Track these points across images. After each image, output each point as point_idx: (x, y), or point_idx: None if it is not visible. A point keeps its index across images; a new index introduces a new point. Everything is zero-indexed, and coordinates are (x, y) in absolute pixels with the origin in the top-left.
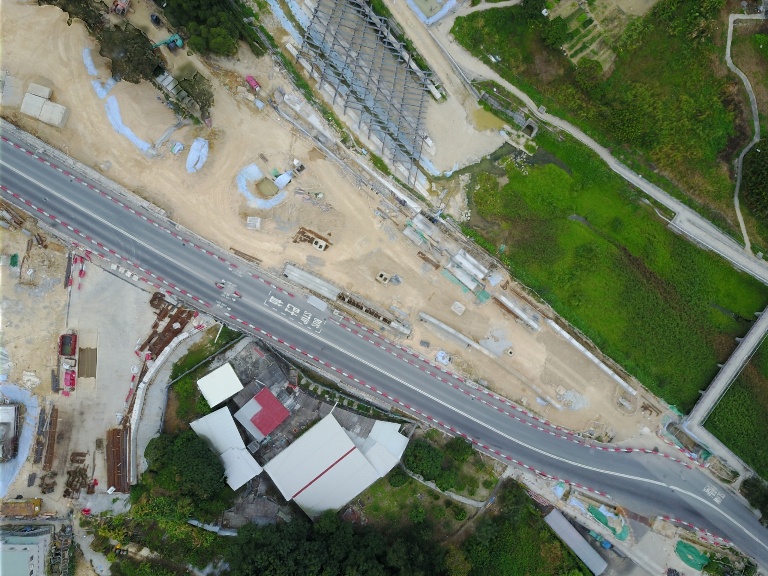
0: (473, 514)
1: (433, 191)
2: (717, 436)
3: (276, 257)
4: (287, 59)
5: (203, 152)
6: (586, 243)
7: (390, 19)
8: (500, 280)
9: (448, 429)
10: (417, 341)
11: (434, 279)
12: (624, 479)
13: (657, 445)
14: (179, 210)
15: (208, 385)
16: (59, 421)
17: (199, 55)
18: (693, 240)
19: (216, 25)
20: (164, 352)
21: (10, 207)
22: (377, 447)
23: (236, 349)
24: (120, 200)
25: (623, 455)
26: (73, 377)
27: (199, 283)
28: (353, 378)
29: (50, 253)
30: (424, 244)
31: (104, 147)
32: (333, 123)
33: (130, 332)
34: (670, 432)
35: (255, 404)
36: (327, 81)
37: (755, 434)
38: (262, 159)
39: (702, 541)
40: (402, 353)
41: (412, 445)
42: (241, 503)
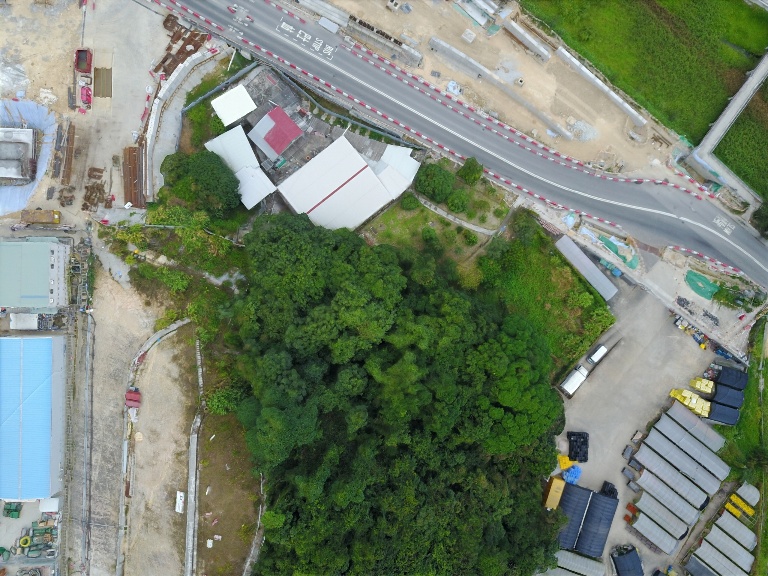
0: (484, 242)
1: None
2: None
3: None
4: None
5: None
6: None
7: None
8: (510, 12)
9: (459, 158)
10: (428, 71)
11: (444, 11)
12: (634, 210)
13: (667, 177)
14: None
15: (222, 105)
16: (76, 138)
17: None
18: None
19: None
20: (178, 68)
21: None
22: (389, 170)
23: (249, 78)
24: None
25: (633, 187)
26: (89, 94)
27: (212, 7)
28: (365, 104)
29: None
30: None
31: None
32: None
33: (144, 53)
34: (680, 165)
35: (268, 120)
36: None
37: (765, 167)
38: None
39: (712, 271)
40: (413, 82)
41: (424, 167)
42: None
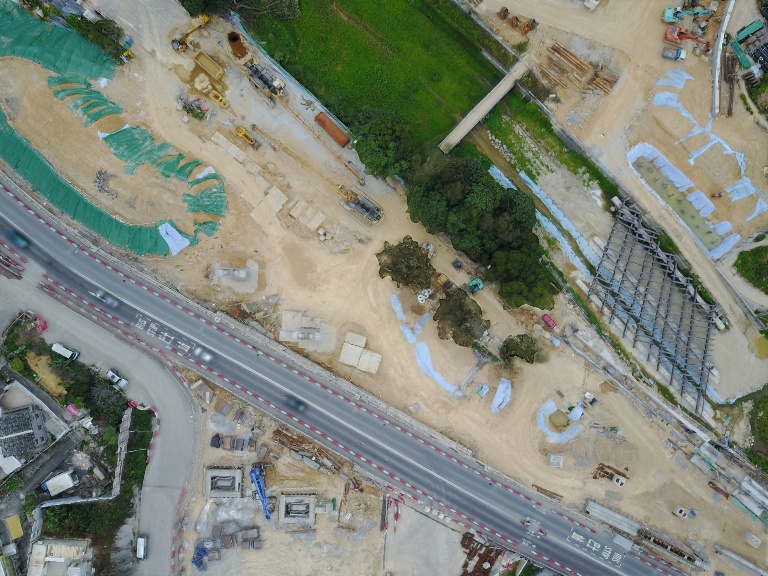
0: None
1: (718, 419)
2: None
3: (576, 493)
4: (576, 293)
5: (507, 393)
6: None
7: (676, 255)
8: None
9: None
10: (711, 572)
11: (725, 508)
12: None
13: None
14: (484, 449)
15: None
16: None
17: (498, 296)
18: None
19: (532, 281)
20: None
21: (328, 452)
22: None
23: None
24: (430, 442)
25: None
26: None
27: (505, 521)
28: None
29: (366, 496)
30: (710, 471)
31: (413, 390)
32: (623, 356)
33: (442, 572)
34: None
35: None
36: (616, 315)
37: None
38: (558, 395)
39: None
40: None
41: None
42: None
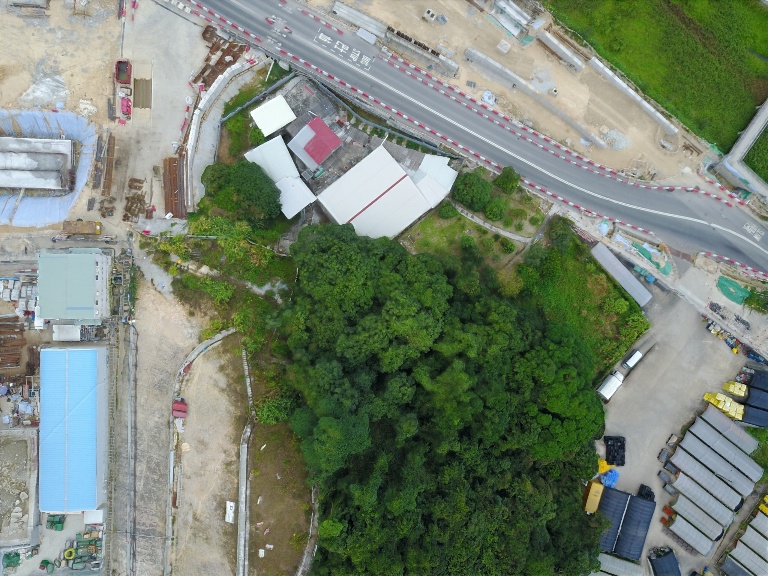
0: (521, 249)
1: None
2: None
3: None
4: None
5: None
6: None
7: None
8: (543, 23)
9: (495, 167)
10: (463, 81)
11: (479, 22)
12: (666, 217)
13: (698, 184)
14: None
15: (261, 115)
16: (116, 149)
17: None
18: None
19: None
20: (218, 79)
21: None
22: (427, 179)
23: (286, 88)
24: None
25: (665, 194)
26: (129, 105)
27: (250, 18)
28: (402, 114)
29: None
30: None
31: None
32: None
33: (183, 64)
34: (710, 173)
35: (309, 130)
36: None
37: None
38: None
39: (743, 276)
40: (449, 92)
41: (462, 176)
42: None
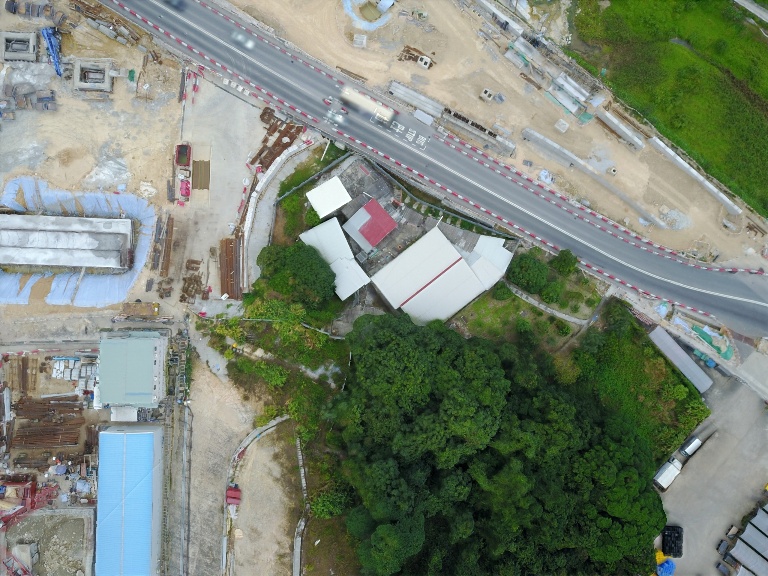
0: (576, 332)
1: (534, 15)
2: None
3: (381, 75)
4: None
5: None
6: (689, 65)
7: None
8: (602, 101)
9: (551, 247)
10: (520, 160)
11: (536, 100)
12: (728, 300)
13: (762, 266)
14: (287, 29)
15: (317, 197)
16: (175, 230)
17: None
18: None
19: None
20: (276, 162)
21: (127, 24)
22: (482, 261)
23: (341, 168)
24: (231, 18)
25: (727, 276)
26: (188, 187)
27: (307, 99)
28: (457, 194)
29: (165, 69)
30: (525, 68)
31: None
32: None
33: (241, 146)
34: None
35: (364, 213)
36: None
37: None
38: None
39: None
40: (505, 171)
41: (517, 258)
42: (350, 310)
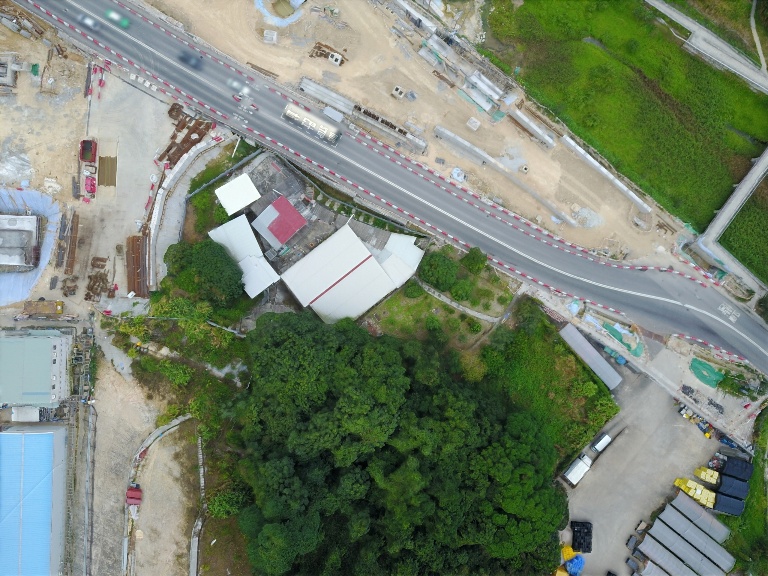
0: (488, 329)
1: (448, 12)
2: (732, 254)
3: (292, 72)
4: None
5: None
6: (601, 64)
7: None
8: (515, 99)
9: (463, 245)
10: (432, 158)
11: (449, 98)
12: (639, 298)
13: (672, 264)
14: (197, 24)
15: (226, 194)
16: (80, 227)
17: None
18: (709, 60)
19: None
20: (183, 158)
21: (31, 17)
22: (393, 258)
23: (253, 164)
24: (139, 12)
25: (638, 274)
26: (93, 183)
27: (217, 95)
28: (369, 192)
29: (70, 63)
30: (439, 66)
31: None
32: None
33: (149, 142)
34: (685, 252)
35: (272, 210)
36: None
37: None
38: None
39: (717, 359)
40: (417, 169)
41: (428, 256)
42: (259, 308)
